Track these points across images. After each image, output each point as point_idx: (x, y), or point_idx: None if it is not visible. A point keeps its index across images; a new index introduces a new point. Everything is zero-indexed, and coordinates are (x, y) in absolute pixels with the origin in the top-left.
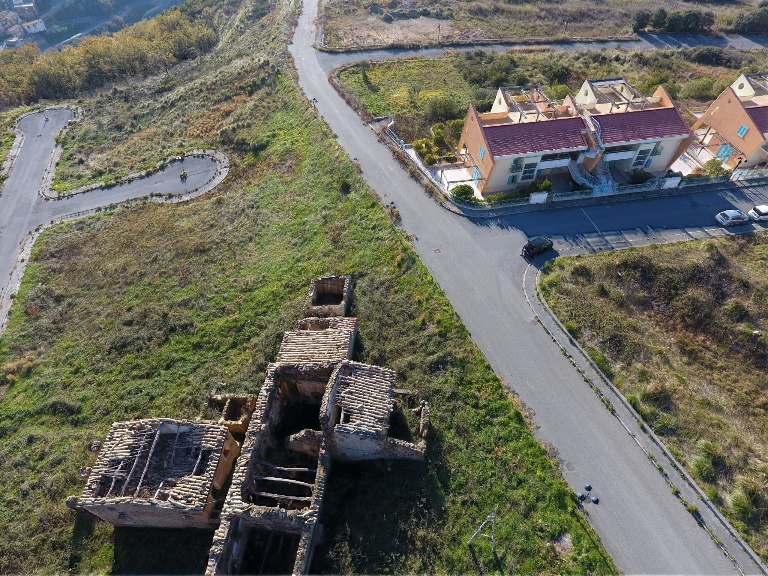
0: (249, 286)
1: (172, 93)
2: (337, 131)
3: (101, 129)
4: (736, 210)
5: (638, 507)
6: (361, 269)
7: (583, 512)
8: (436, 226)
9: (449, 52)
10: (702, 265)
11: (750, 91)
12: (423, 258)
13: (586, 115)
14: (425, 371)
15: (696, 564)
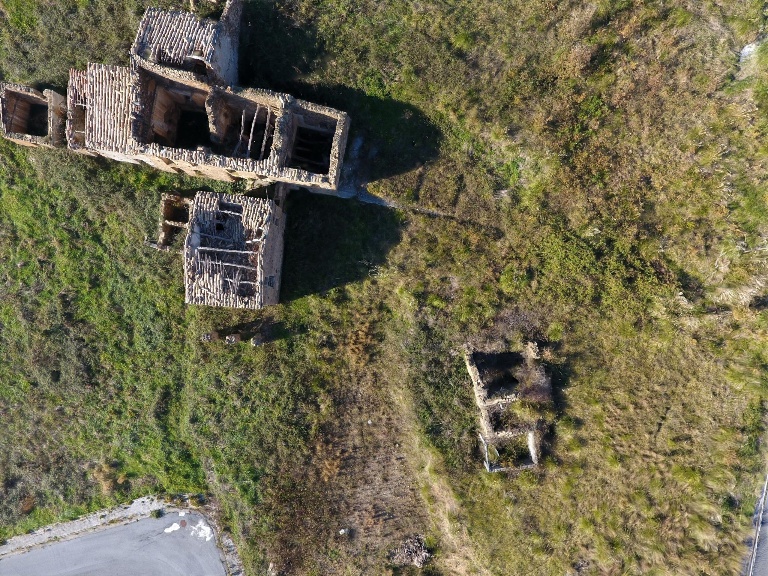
0: (7, 233)
1: None
2: None
3: None
4: None
5: None
6: None
7: None
8: None
9: None
10: None
11: None
12: None
13: None
14: None
15: None
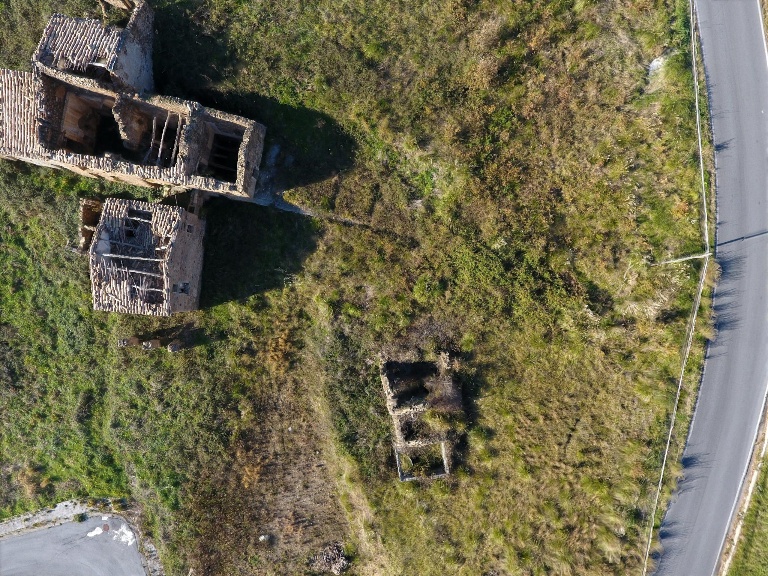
0: None
1: None
2: None
3: None
4: None
5: None
6: None
7: None
8: None
9: None
10: None
11: None
12: None
13: None
14: (62, 2)
15: None
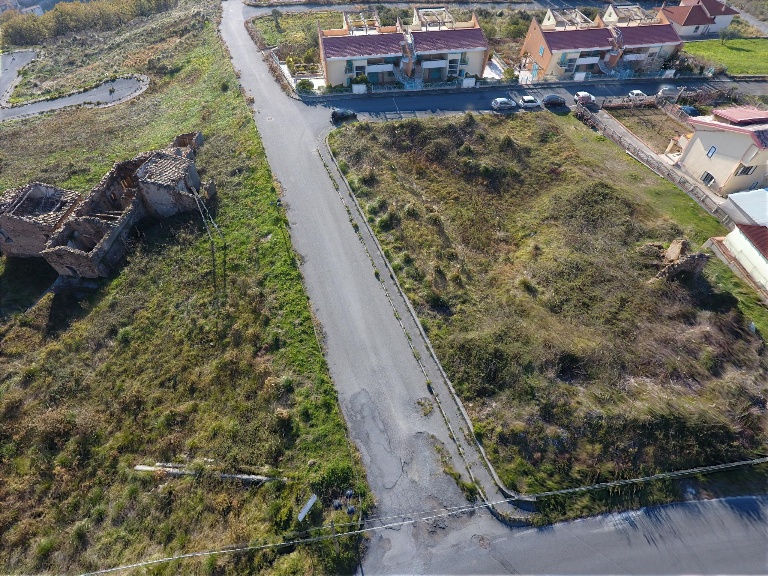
0: (136, 147)
1: (119, 37)
2: (234, 55)
3: (57, 64)
4: (509, 99)
5: (323, 226)
6: (215, 132)
7: (288, 228)
8: (277, 106)
9: (357, 7)
10: (454, 125)
11: (553, 21)
12: (257, 122)
13: (408, 32)
14: (227, 175)
15: (341, 246)
